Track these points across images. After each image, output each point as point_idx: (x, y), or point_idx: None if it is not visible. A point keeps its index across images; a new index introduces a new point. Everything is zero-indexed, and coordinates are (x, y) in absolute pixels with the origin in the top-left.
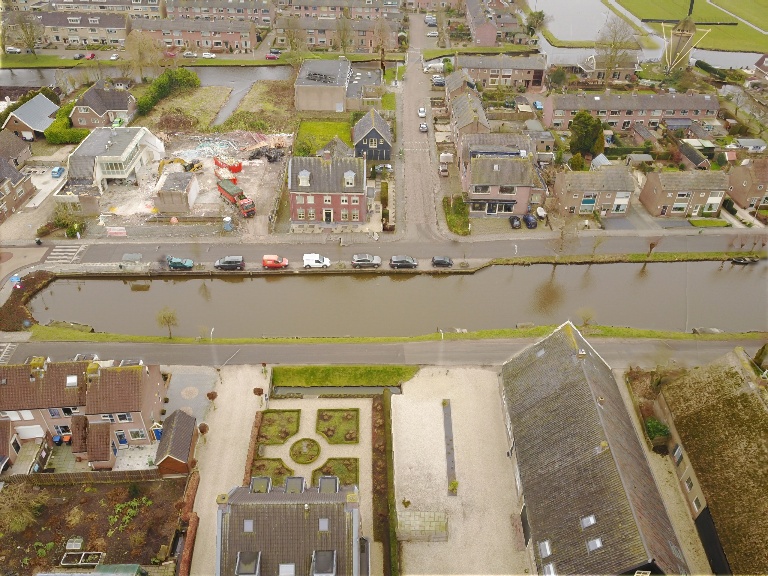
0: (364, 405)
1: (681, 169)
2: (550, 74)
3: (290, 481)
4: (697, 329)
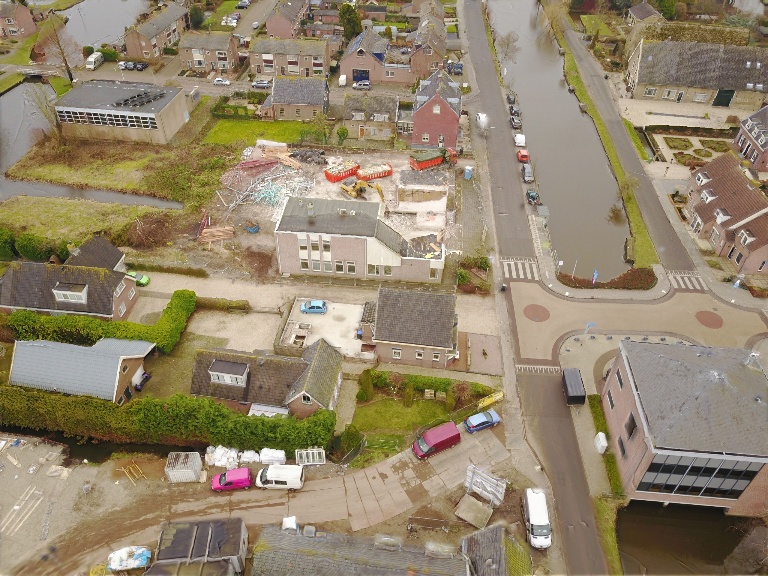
0: (658, 136)
1: (375, 21)
2: (191, 14)
3: (759, 128)
4: (563, 52)
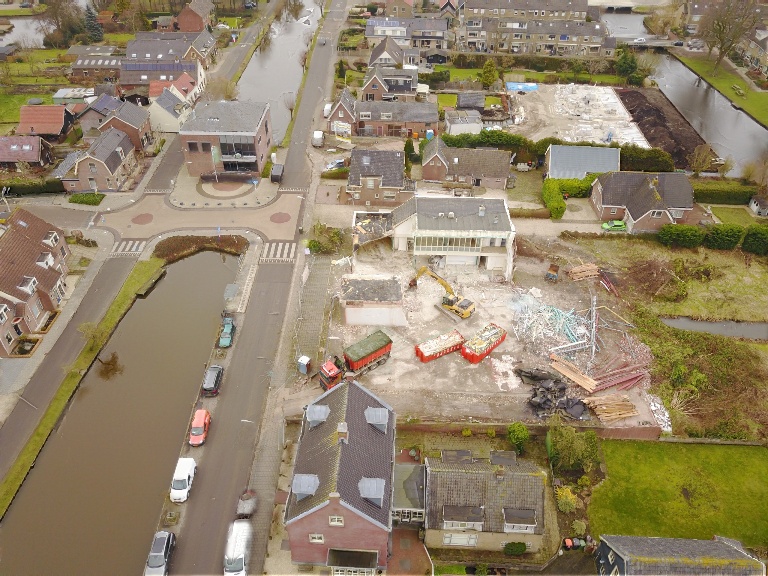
0: None
1: None
2: None
3: None
4: None
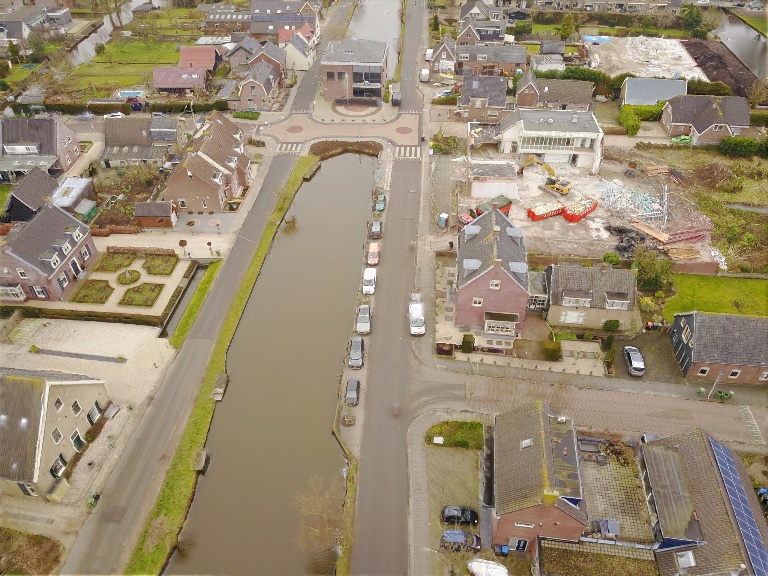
0: (156, 311)
1: None
2: None
3: None
4: None
